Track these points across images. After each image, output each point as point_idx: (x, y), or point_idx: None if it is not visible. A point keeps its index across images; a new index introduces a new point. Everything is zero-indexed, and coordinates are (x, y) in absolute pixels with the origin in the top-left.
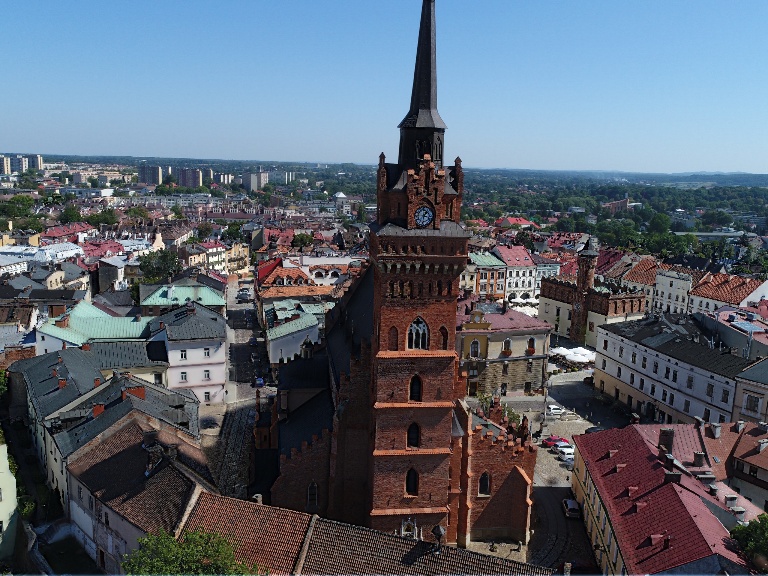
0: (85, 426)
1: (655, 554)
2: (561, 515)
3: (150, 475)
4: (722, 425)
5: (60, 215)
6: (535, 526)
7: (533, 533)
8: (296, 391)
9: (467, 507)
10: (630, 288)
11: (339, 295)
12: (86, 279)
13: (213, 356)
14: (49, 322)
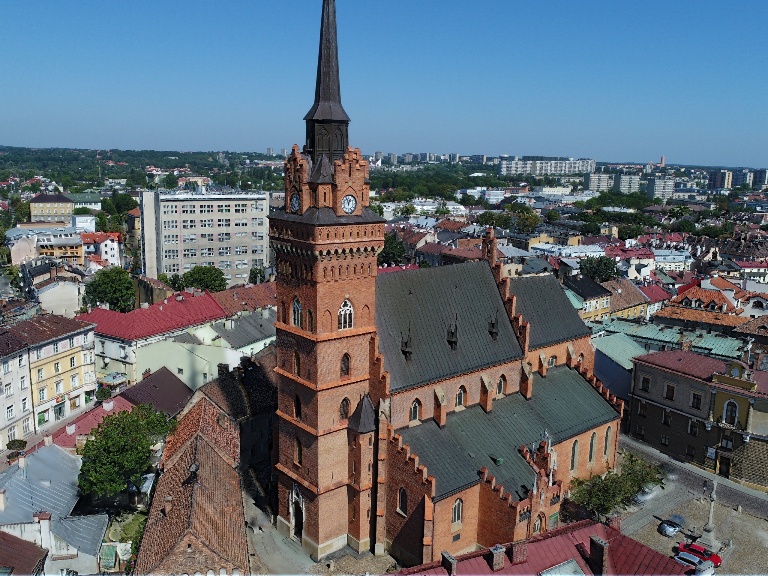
0: None
1: None
2: None
3: None
4: None
5: (673, 225)
6: None
7: None
8: None
9: None
10: None
11: (742, 329)
12: None
13: None
14: None
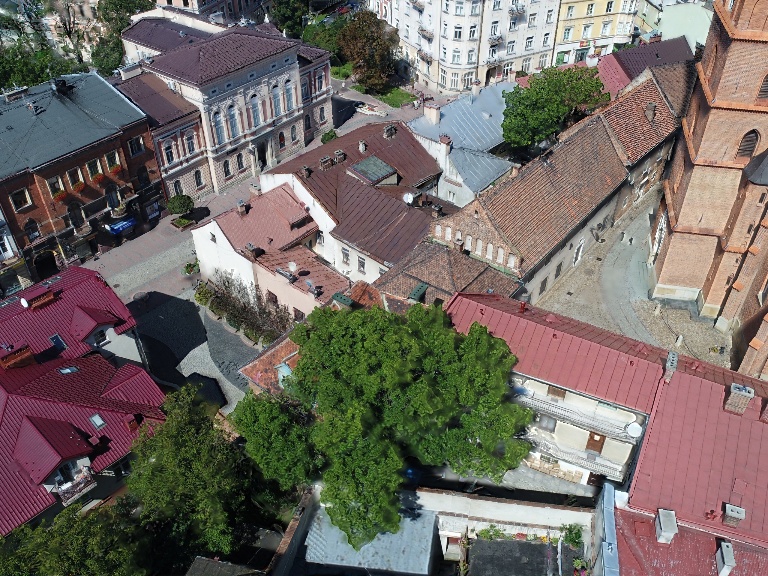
0: None
1: None
2: None
3: None
4: None
5: None
6: None
7: None
8: None
9: None
10: None
11: None
12: None
13: None
14: None
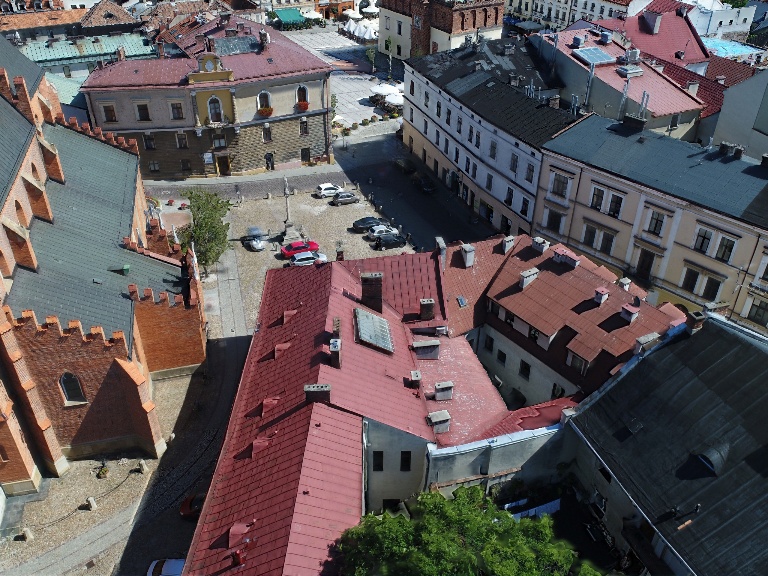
0: None
1: (220, 572)
2: None
3: None
4: (481, 245)
5: None
6: (189, 419)
7: (173, 438)
8: None
9: (40, 428)
10: None
11: None
12: None
13: None
14: None
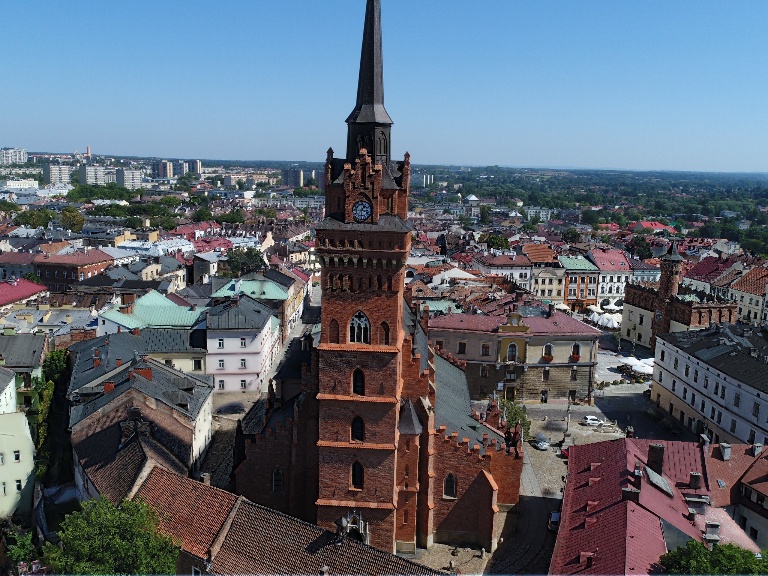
0: (96, 401)
1: (577, 572)
2: (544, 527)
3: (122, 448)
4: (735, 446)
5: (193, 214)
6: (510, 535)
7: (502, 541)
8: (290, 381)
9: (428, 507)
10: (721, 297)
11: None
12: (182, 272)
13: (249, 346)
14: (115, 308)
